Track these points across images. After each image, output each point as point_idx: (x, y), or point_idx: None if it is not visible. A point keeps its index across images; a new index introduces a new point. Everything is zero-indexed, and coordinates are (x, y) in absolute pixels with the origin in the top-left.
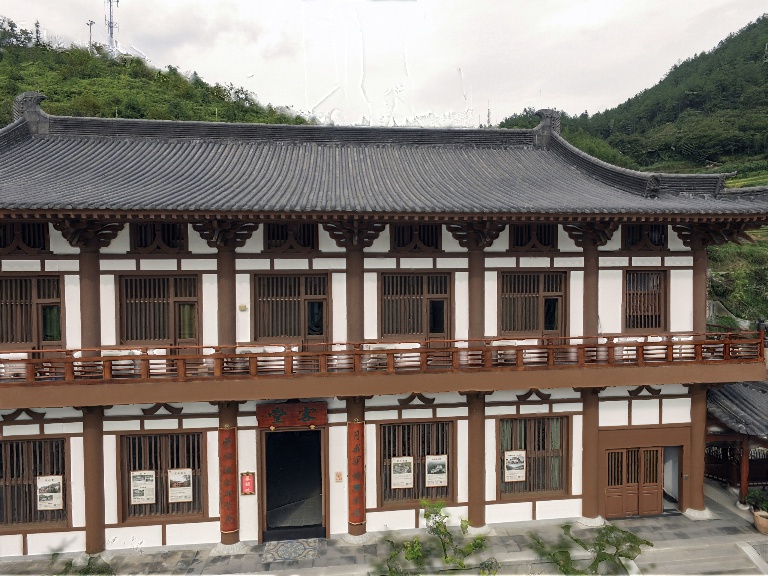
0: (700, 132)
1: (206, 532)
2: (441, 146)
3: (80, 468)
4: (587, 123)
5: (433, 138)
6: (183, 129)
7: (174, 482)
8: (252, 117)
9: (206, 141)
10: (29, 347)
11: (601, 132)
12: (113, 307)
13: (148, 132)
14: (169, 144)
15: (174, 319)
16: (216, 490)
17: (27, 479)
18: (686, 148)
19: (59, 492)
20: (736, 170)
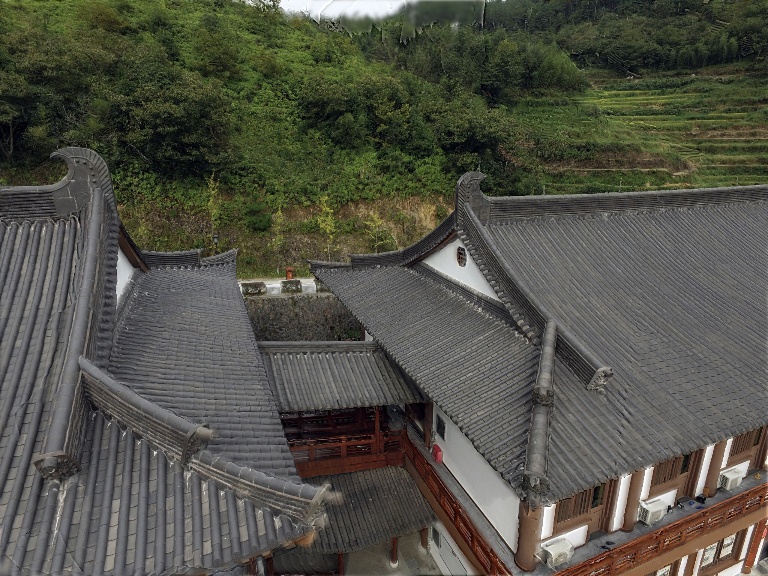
0: (626, 42)
1: (736, 569)
2: (762, 202)
3: (686, 557)
4: (506, 11)
5: (759, 195)
6: (598, 203)
7: (725, 545)
8: (283, 32)
9: (613, 213)
10: (678, 485)
11: (518, 22)
12: (732, 440)
13: (571, 209)
14: (589, 221)
15: (754, 436)
16: (747, 542)
17: (650, 574)
18: (613, 57)
19: (667, 575)
20: (654, 85)
